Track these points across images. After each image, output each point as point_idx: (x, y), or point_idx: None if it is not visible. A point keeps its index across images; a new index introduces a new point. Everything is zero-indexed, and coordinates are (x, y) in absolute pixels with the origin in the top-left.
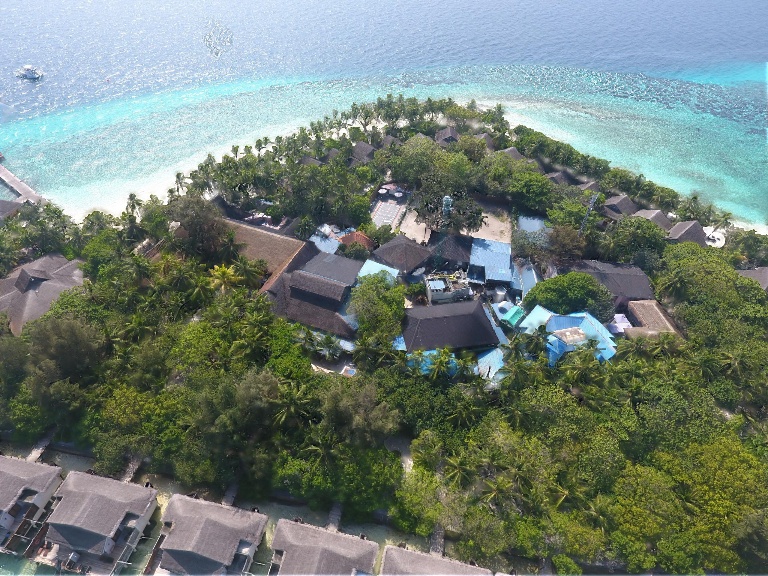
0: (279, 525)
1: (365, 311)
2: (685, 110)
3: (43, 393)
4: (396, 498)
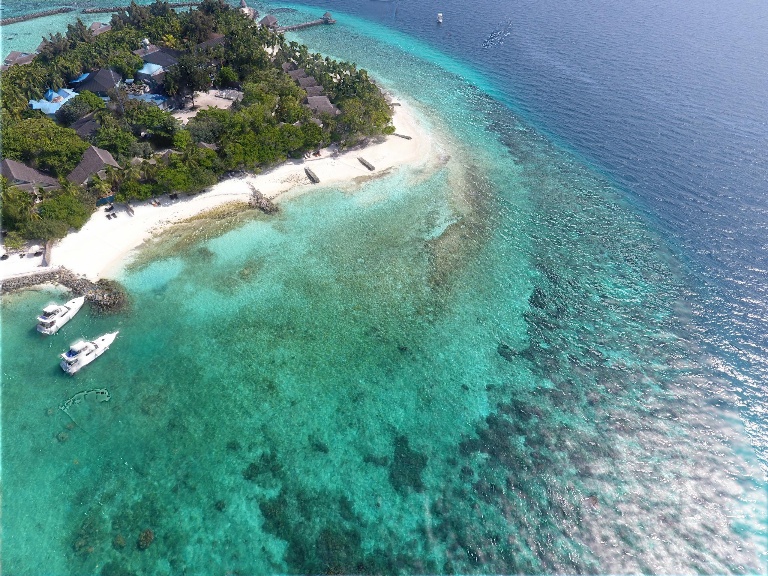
0: None
1: None
2: (499, 372)
3: None
4: None
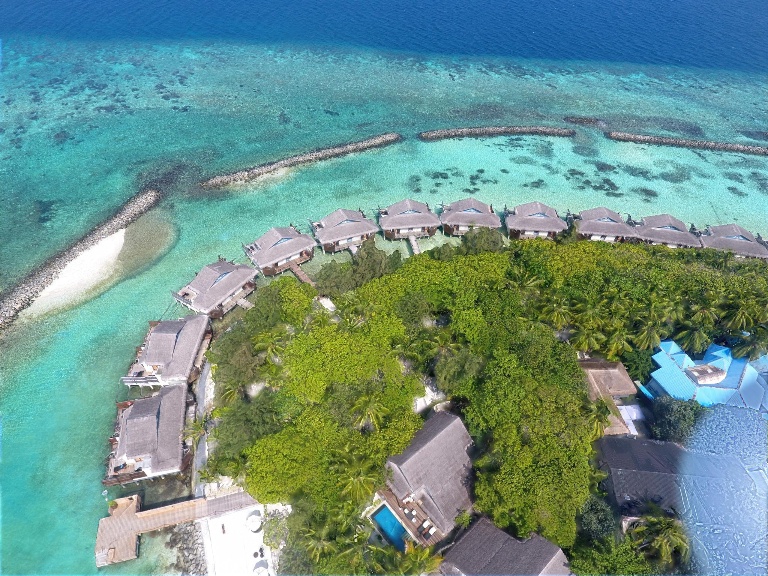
0: None
1: None
2: None
3: None
4: None
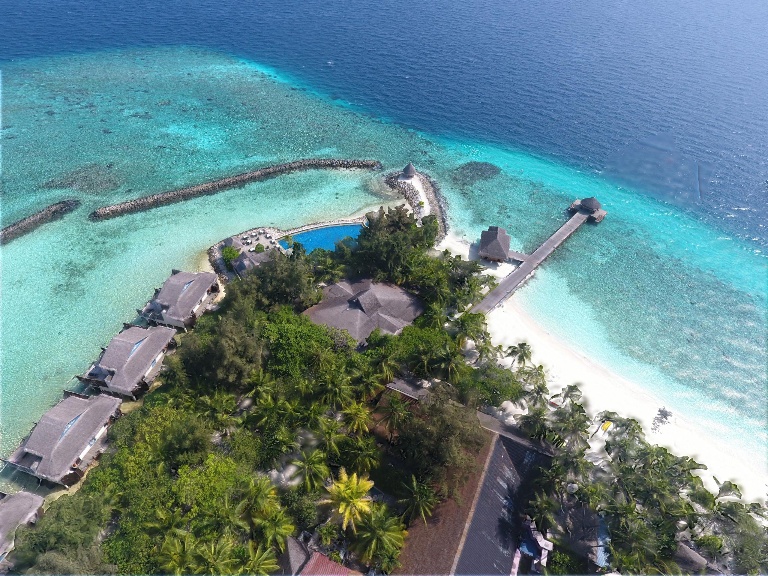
0: None
1: None
2: None
3: None
4: None
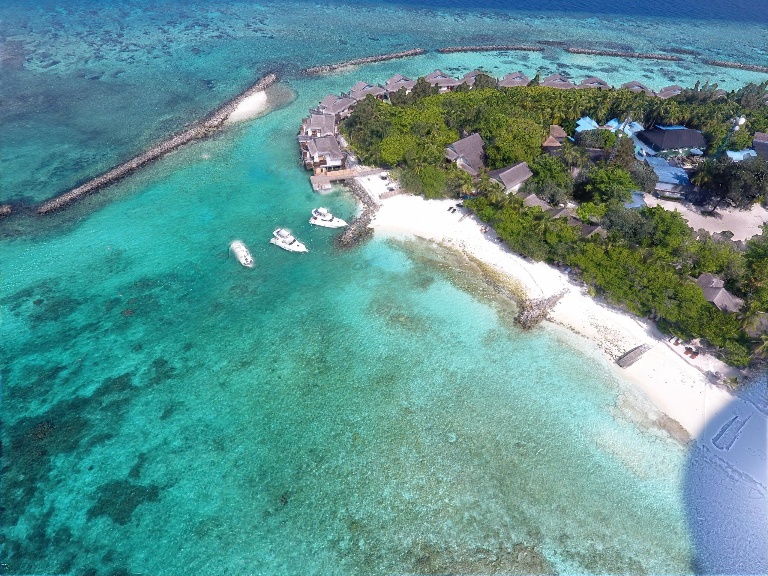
0: None
1: None
2: None
3: None
4: None
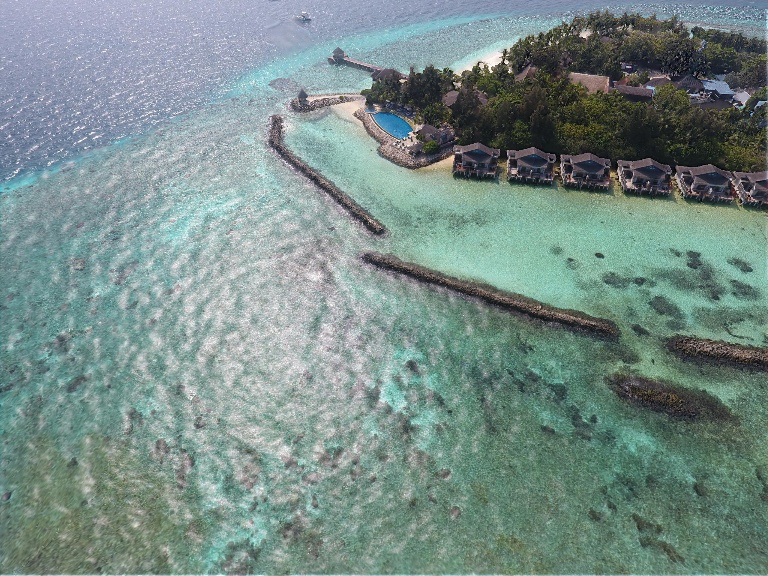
0: (678, 166)
1: (672, 97)
2: None
3: (541, 120)
4: (726, 162)
